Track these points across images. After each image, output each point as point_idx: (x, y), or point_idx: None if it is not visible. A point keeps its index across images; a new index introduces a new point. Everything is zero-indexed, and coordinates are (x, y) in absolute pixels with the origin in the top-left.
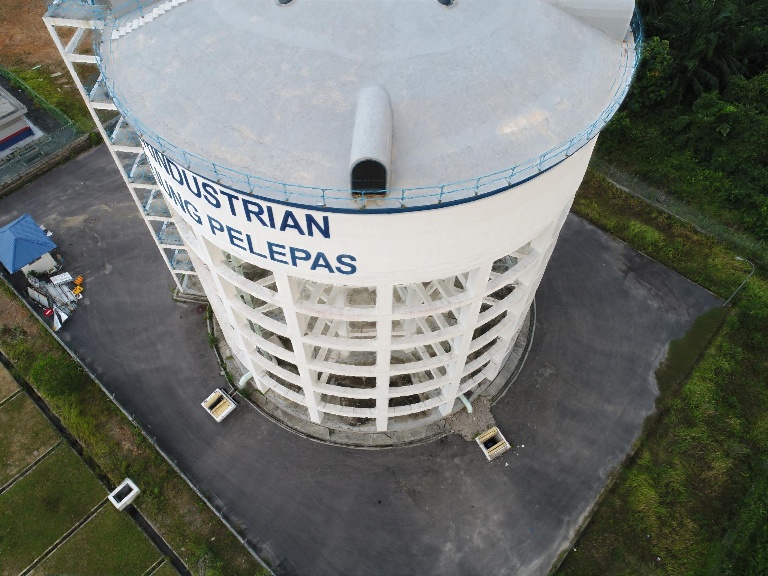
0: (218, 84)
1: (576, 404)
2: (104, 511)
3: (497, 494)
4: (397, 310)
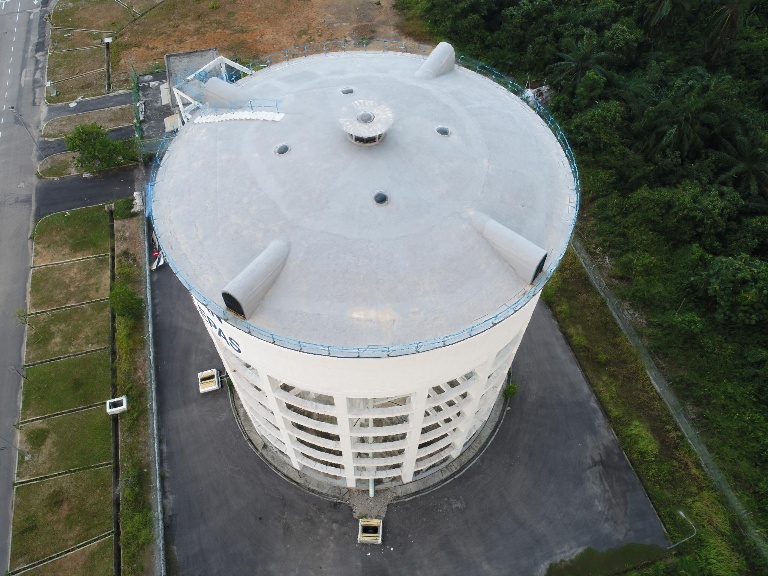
0: (207, 191)
1: (460, 545)
2: (101, 409)
3: (345, 571)
4: (278, 392)
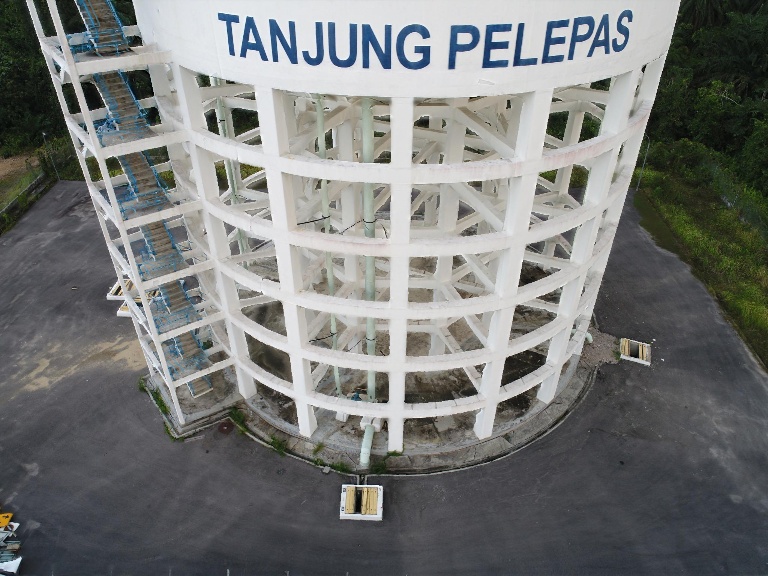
0: None
1: (644, 291)
2: None
3: (687, 385)
4: None
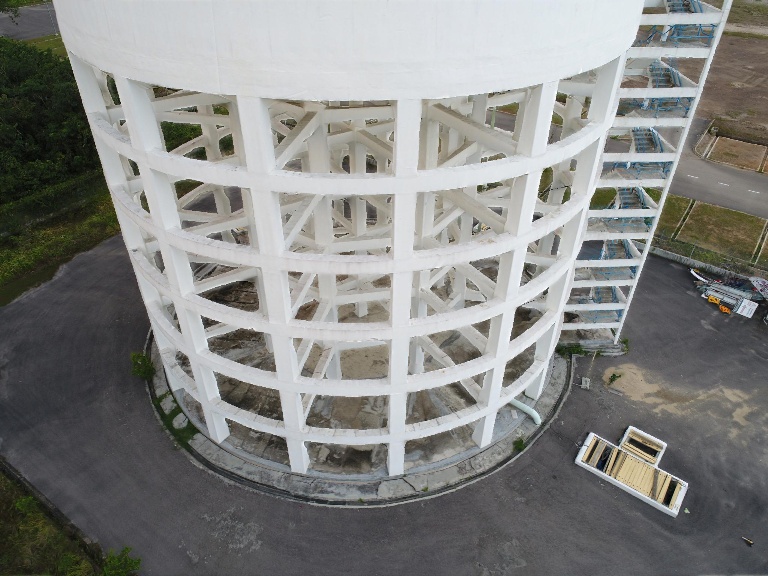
0: None
1: None
2: None
3: None
4: None
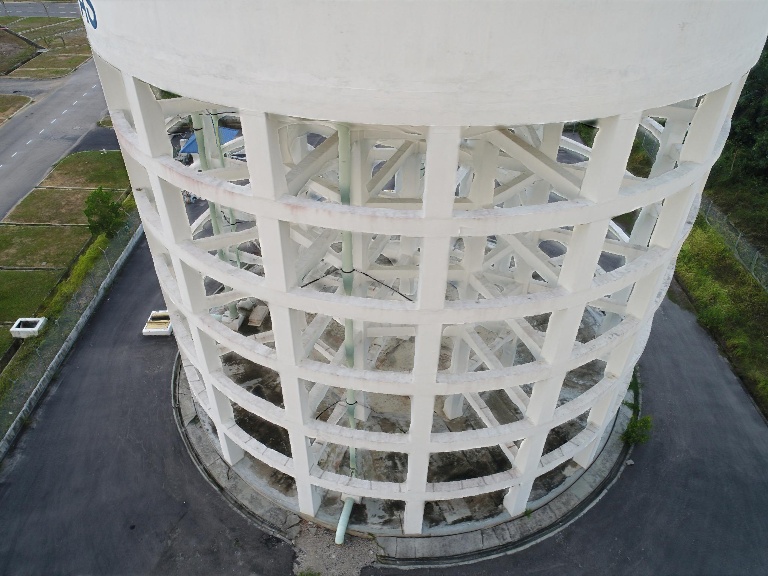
0: None
1: None
2: (8, 328)
3: None
4: (164, 158)
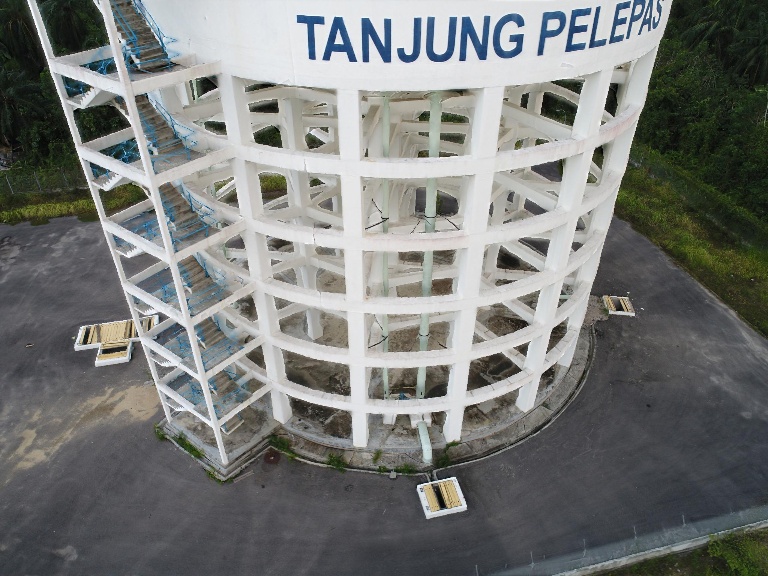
0: None
1: None
2: None
3: (670, 327)
4: None
